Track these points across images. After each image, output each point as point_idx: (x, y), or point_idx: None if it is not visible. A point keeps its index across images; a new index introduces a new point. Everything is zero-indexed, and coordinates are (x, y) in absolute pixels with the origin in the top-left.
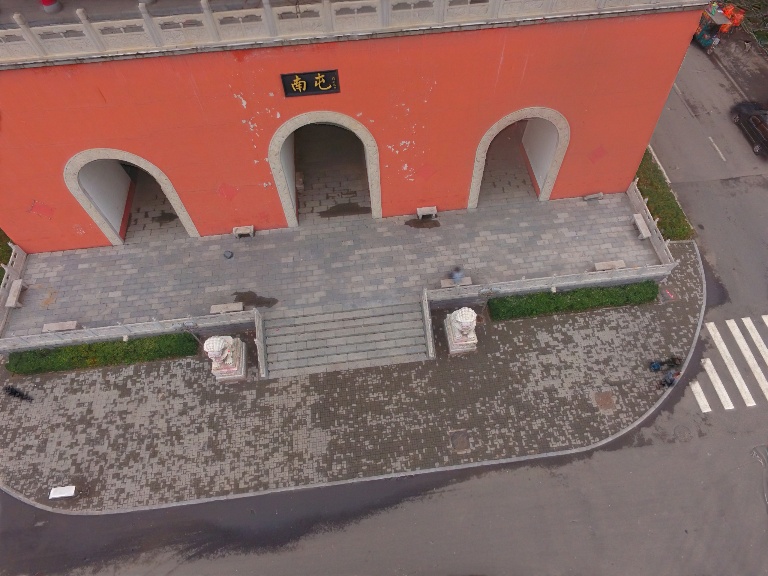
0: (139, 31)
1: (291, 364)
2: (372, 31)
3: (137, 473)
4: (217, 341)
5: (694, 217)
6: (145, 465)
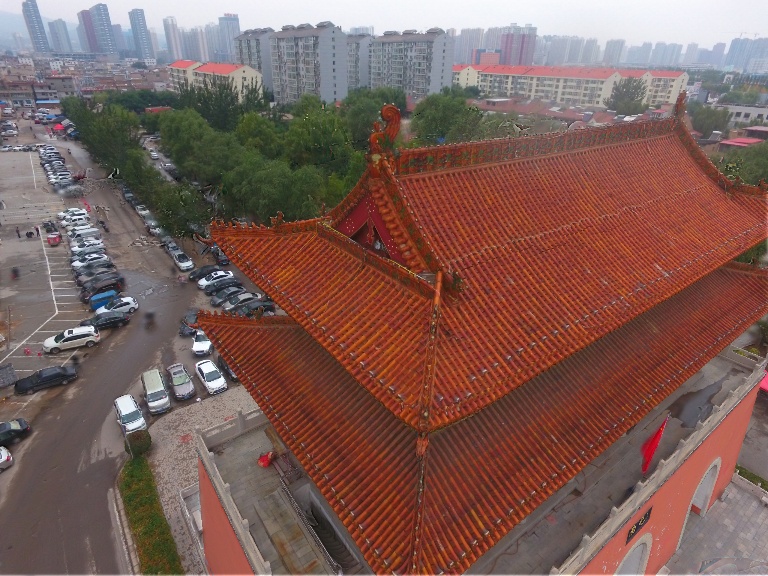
0: (575, 559)
1: None
2: (673, 470)
3: None
4: None
5: (765, 478)
6: None
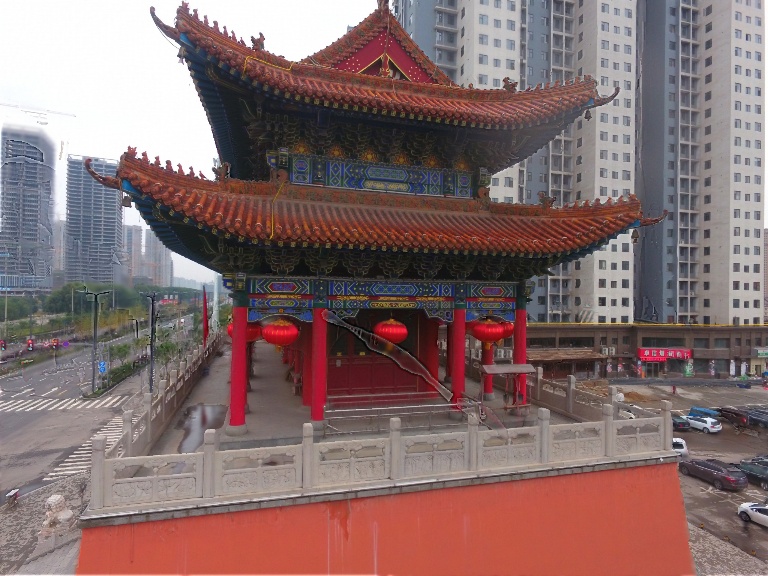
0: None
1: (25, 572)
2: None
3: (3, 523)
4: (55, 498)
5: None
6: (5, 524)
